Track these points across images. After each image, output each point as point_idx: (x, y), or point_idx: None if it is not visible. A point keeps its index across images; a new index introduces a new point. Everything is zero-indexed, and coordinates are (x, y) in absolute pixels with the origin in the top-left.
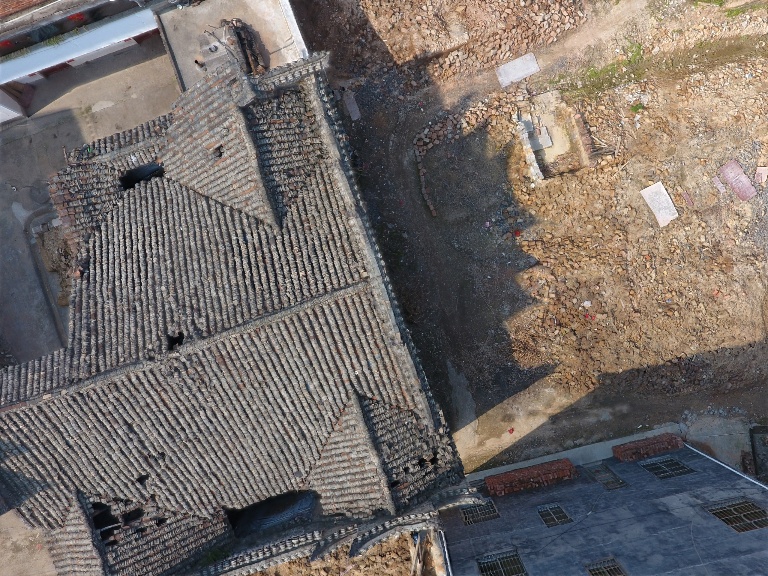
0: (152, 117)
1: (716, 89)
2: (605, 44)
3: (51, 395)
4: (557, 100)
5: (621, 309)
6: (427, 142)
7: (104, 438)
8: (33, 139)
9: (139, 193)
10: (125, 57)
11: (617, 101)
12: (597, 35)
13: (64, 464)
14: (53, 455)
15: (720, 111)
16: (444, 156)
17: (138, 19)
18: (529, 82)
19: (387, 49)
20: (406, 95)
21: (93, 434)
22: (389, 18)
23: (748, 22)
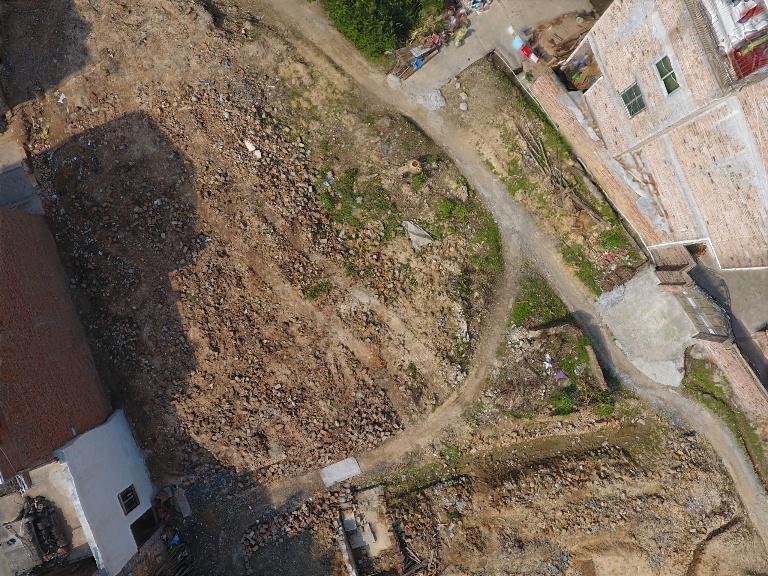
0: None
1: (527, 499)
2: (423, 449)
3: None
4: (379, 499)
5: None
6: (253, 545)
7: None
8: None
9: None
10: None
11: (435, 504)
12: (415, 441)
13: None
14: None
15: (530, 522)
16: (269, 558)
17: None
18: (352, 481)
19: (213, 456)
20: (235, 493)
21: None
22: (210, 436)
23: (560, 428)
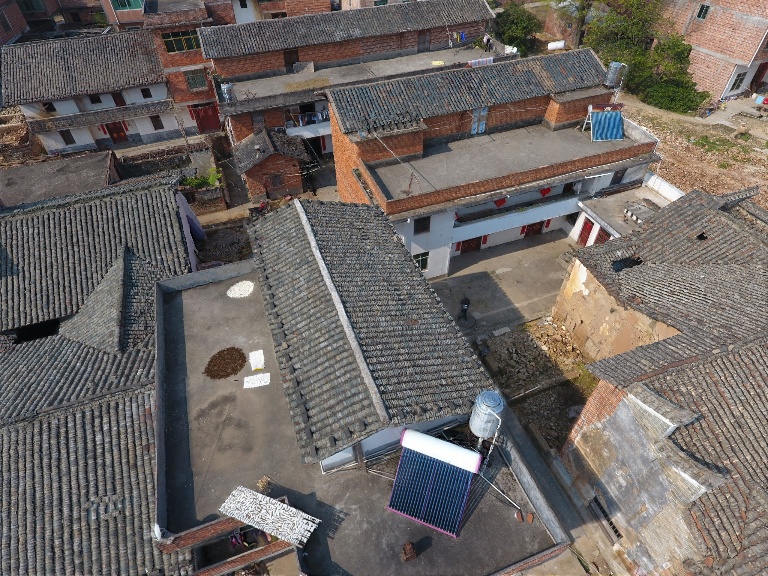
0: (544, 276)
1: None
2: None
3: (719, 350)
4: None
5: None
6: None
7: (766, 411)
8: (452, 289)
9: (633, 271)
10: (513, 246)
11: None
12: None
13: (733, 442)
14: (720, 429)
15: None
16: None
17: (567, 204)
18: None
19: None
20: None
21: (756, 404)
22: None
23: None
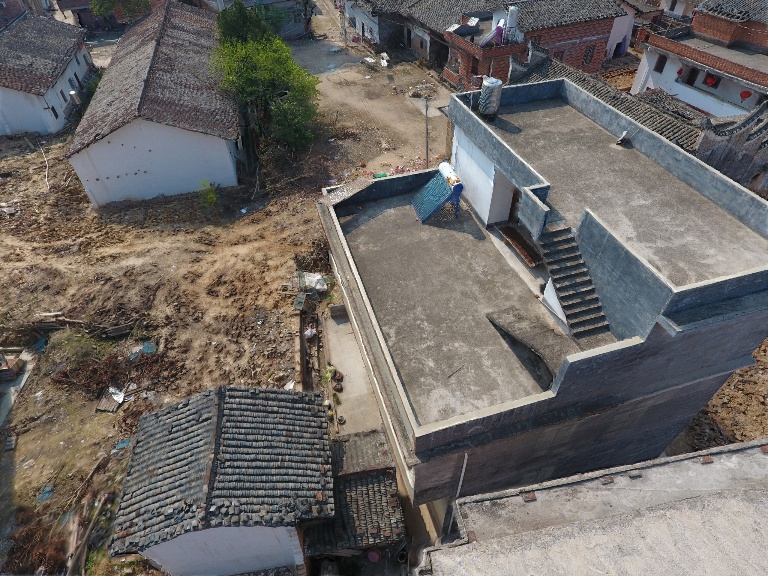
0: None
1: None
2: None
3: None
4: None
5: (756, 388)
6: None
7: None
8: None
9: None
10: None
11: None
12: None
13: None
14: None
15: None
16: None
17: None
18: None
19: None
20: None
21: None
22: None
23: None
